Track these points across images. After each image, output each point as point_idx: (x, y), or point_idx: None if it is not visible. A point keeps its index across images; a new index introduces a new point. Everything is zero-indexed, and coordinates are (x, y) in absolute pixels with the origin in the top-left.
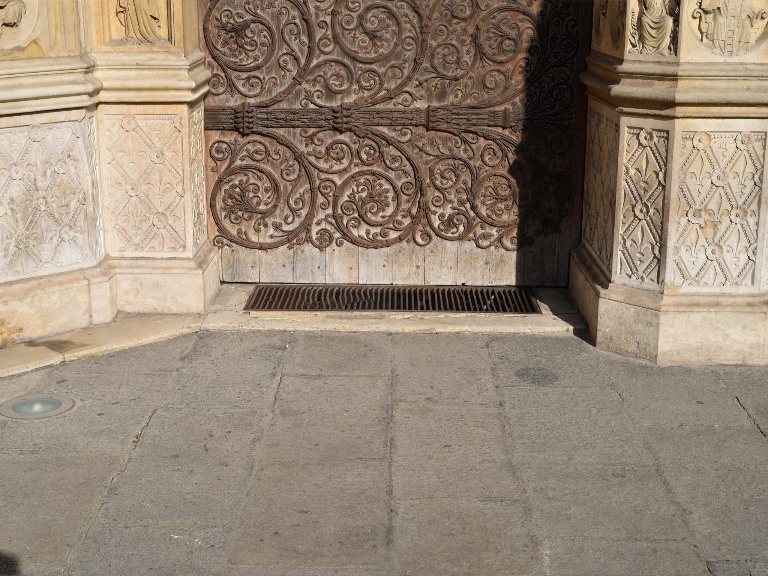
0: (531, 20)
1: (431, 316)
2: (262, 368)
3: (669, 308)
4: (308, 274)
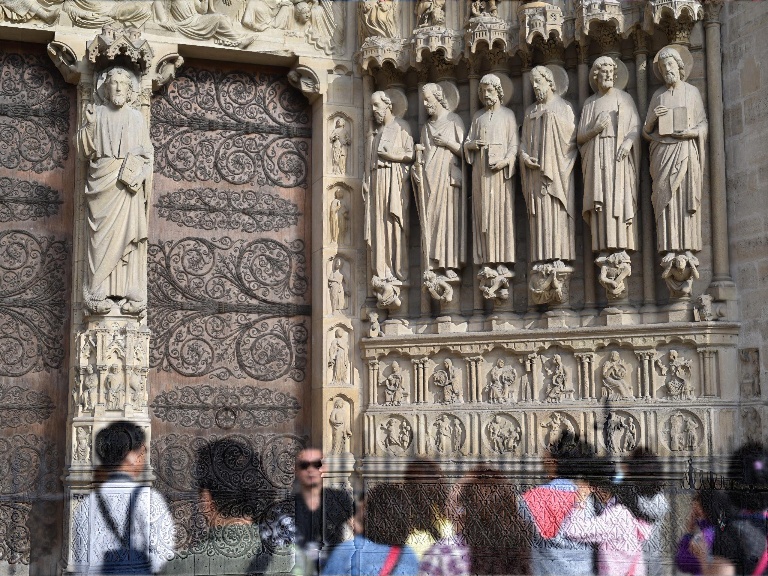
0: (36, 452)
1: None
2: None
3: (92, 571)
4: None
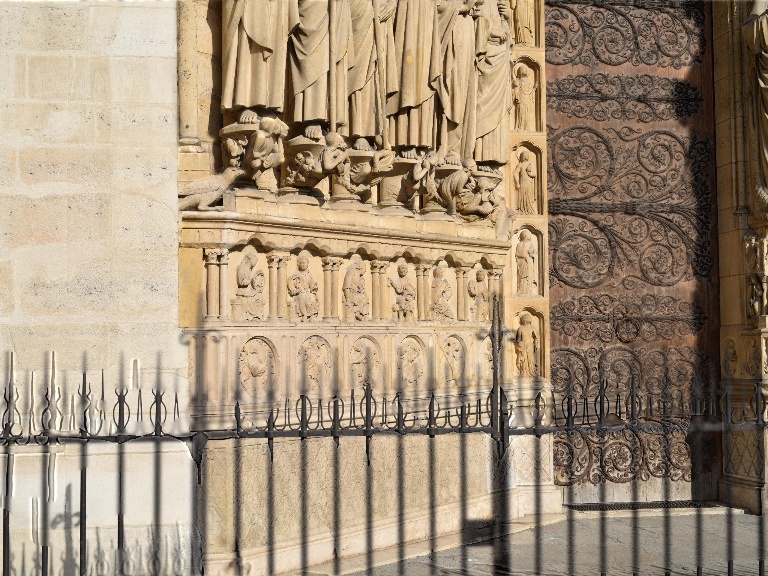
0: (692, 365)
1: (672, 510)
2: (626, 526)
3: None
4: (588, 498)
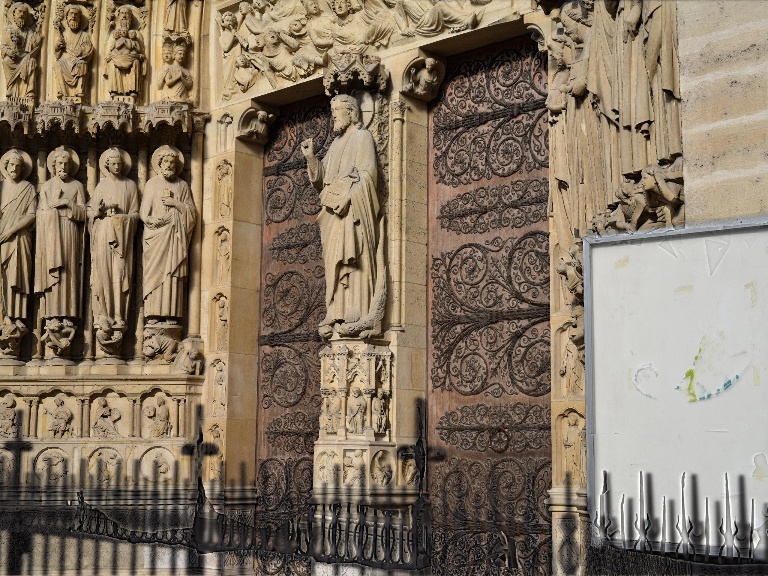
0: None
1: None
2: None
3: None
4: None
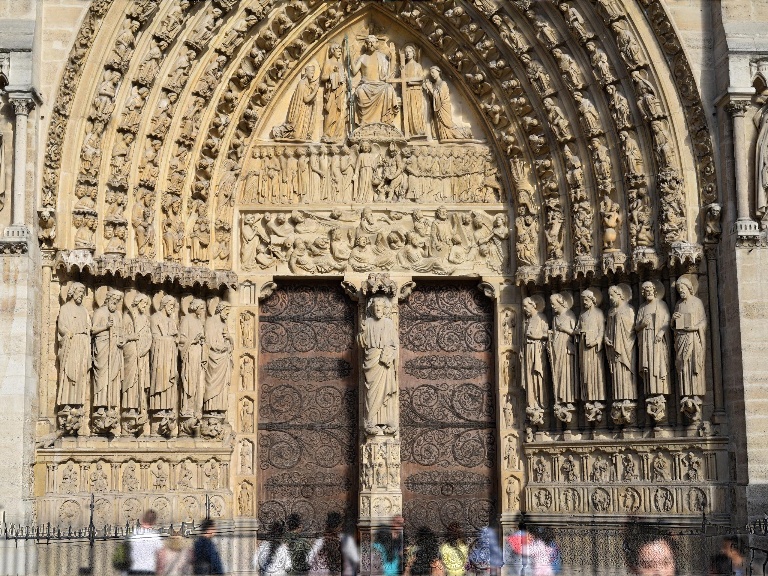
0: (343, 509)
1: None
2: None
3: (372, 575)
4: None
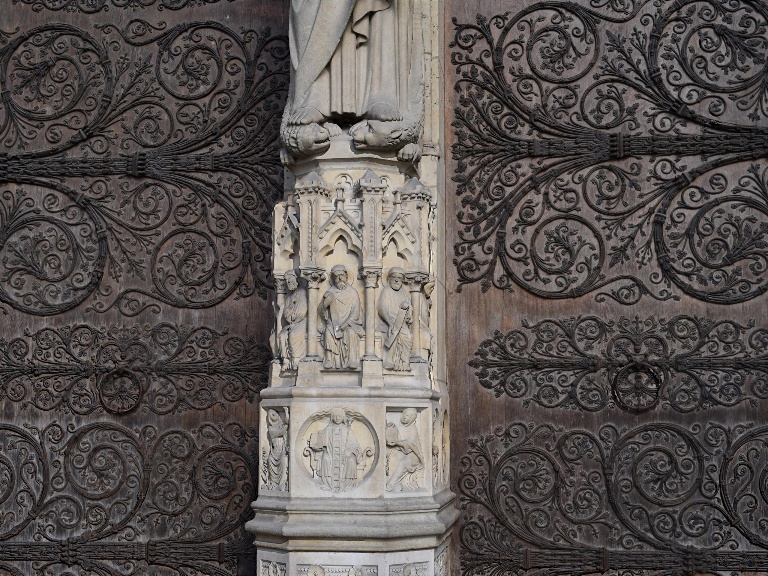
0: (243, 459)
1: None
2: None
3: None
4: None
